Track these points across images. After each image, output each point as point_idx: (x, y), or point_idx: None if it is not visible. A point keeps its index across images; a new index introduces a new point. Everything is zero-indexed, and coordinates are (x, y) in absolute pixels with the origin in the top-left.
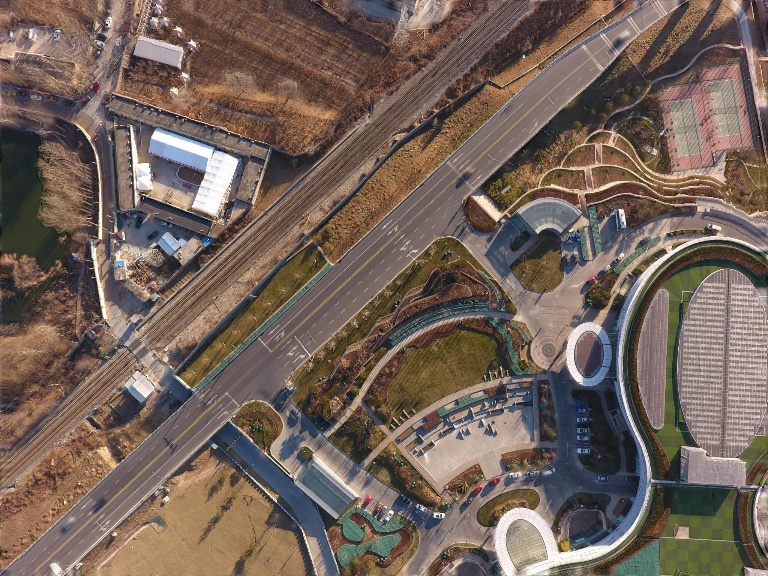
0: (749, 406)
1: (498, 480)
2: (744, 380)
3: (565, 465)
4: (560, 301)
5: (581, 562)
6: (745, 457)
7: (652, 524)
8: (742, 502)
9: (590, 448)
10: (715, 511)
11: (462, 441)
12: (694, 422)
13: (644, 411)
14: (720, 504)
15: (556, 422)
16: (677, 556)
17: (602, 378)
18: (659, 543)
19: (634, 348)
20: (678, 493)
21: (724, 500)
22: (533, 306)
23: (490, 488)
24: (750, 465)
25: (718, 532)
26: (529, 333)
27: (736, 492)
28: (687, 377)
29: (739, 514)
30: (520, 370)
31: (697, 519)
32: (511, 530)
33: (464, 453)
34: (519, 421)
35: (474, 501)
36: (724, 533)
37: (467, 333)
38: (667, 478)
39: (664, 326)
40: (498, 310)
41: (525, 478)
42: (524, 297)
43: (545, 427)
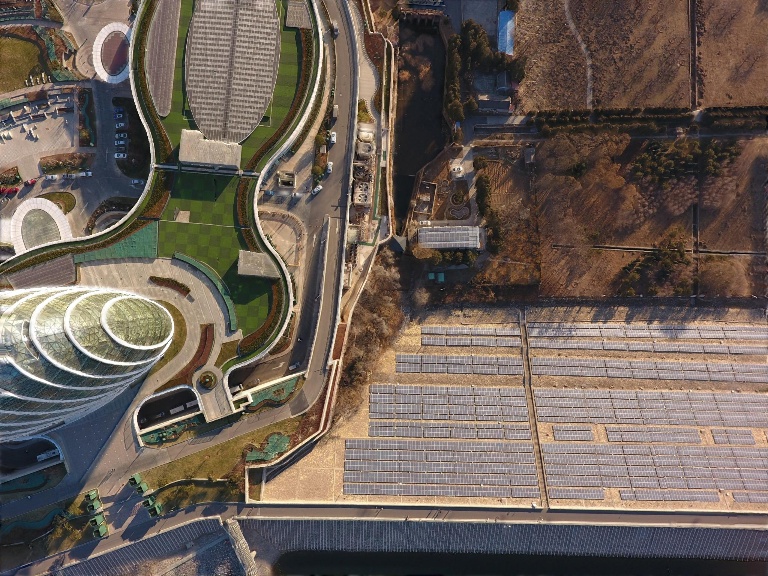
0: (254, 95)
1: (33, 181)
2: (250, 70)
3: (103, 170)
4: (108, 13)
5: (79, 241)
6: (249, 146)
7: (151, 206)
8: (242, 187)
9: (127, 153)
10: (216, 197)
11: (3, 145)
12: (198, 109)
13: (150, 98)
14: (222, 190)
15: (96, 128)
16: (176, 239)
17: (127, 76)
18: (158, 225)
19: (143, 37)
20: (180, 178)
21: (226, 186)
22: (81, 17)
23: (27, 190)
24: (253, 153)
25: (218, 217)
26: (75, 42)
27: (238, 179)
28: (194, 66)
29: (238, 199)
30: (61, 76)
31: (198, 204)
32: (27, 219)
33: (4, 156)
34: (61, 127)
35: (10, 202)
36: (224, 218)
37: (11, 39)
38: (168, 162)
39: (175, 17)
40: (43, 18)
41: (63, 182)
42: (73, 9)
43: (76, 127)
